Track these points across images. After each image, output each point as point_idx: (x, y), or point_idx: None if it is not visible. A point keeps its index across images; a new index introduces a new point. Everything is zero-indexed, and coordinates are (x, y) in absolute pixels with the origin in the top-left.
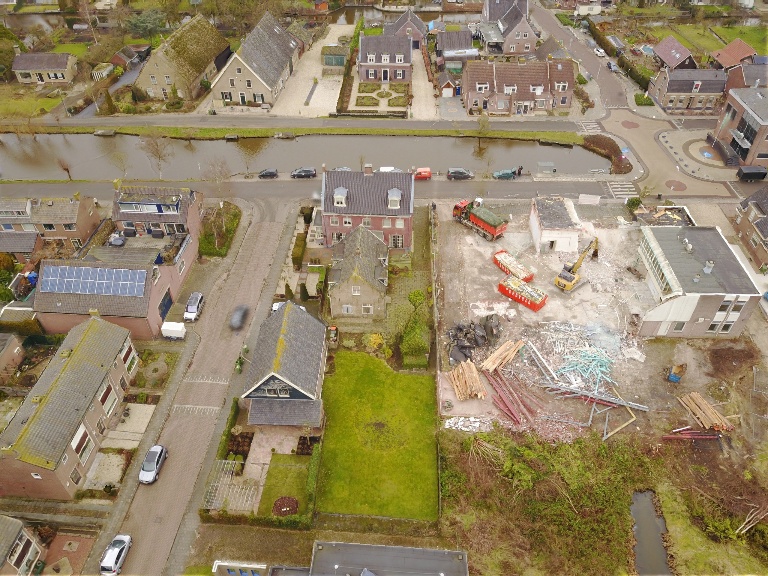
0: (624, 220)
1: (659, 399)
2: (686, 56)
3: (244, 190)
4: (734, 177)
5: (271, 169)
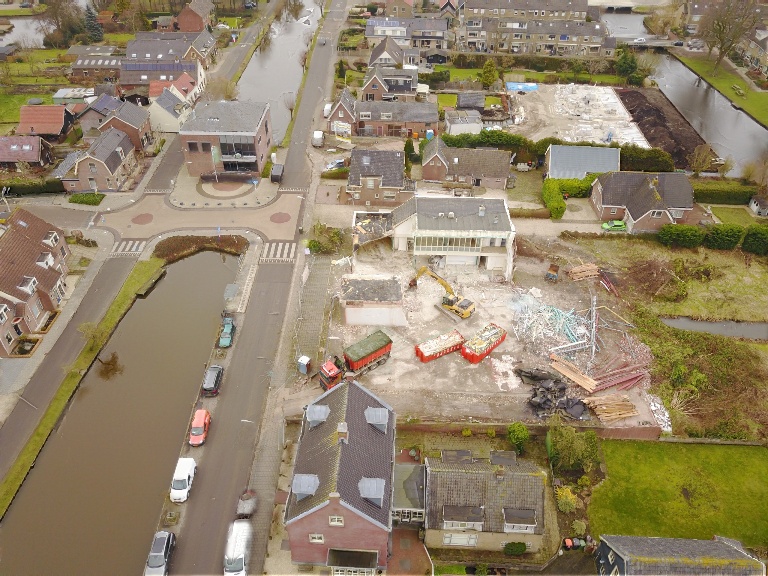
0: (341, 260)
1: (579, 290)
2: (39, 142)
3: None
4: (273, 185)
5: None
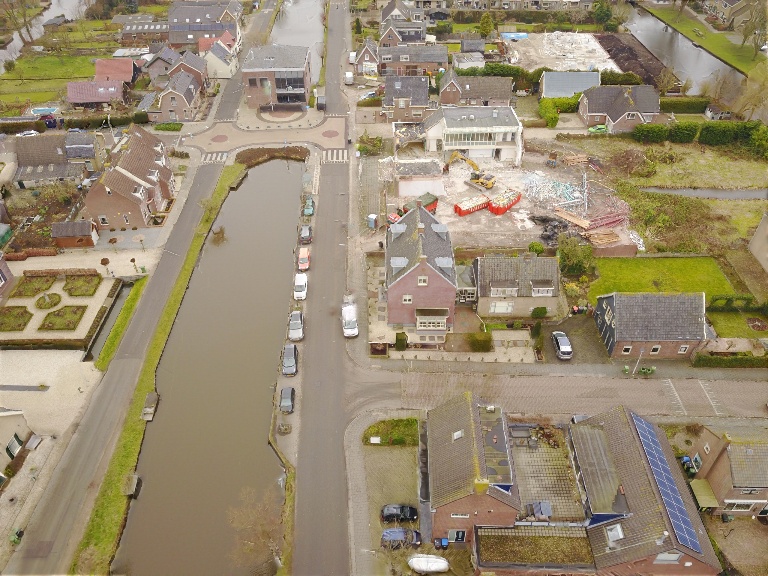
0: (385, 158)
1: (573, 171)
2: (121, 85)
3: (325, 427)
4: (319, 112)
5: (287, 391)
